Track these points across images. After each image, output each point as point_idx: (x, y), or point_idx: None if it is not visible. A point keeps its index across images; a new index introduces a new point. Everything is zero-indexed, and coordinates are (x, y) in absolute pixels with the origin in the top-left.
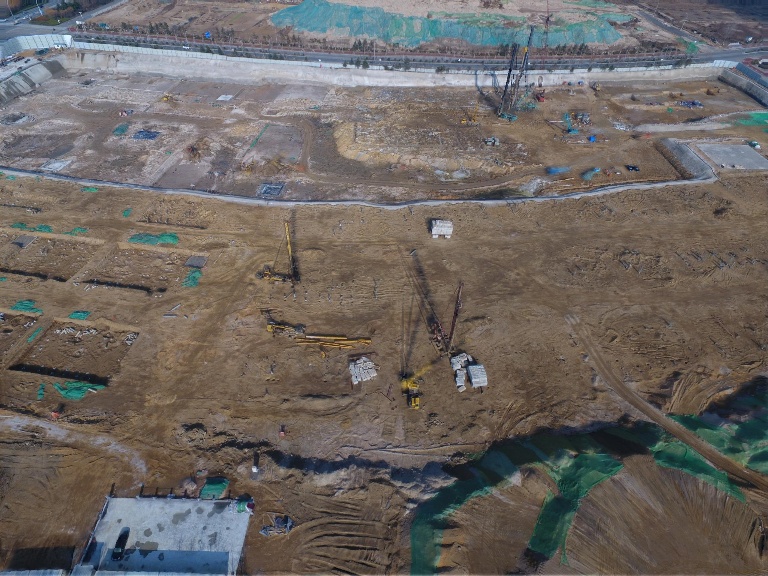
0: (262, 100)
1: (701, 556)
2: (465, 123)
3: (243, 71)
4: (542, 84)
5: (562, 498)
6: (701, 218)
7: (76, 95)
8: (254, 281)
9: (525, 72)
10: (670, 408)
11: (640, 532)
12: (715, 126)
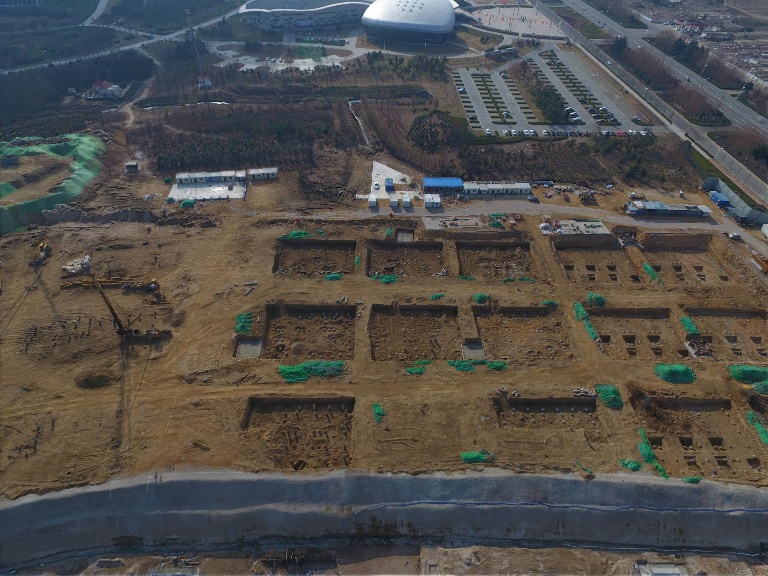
0: None
1: None
2: None
3: None
4: None
5: None
6: None
7: None
8: (174, 329)
9: None
10: None
11: None
12: None
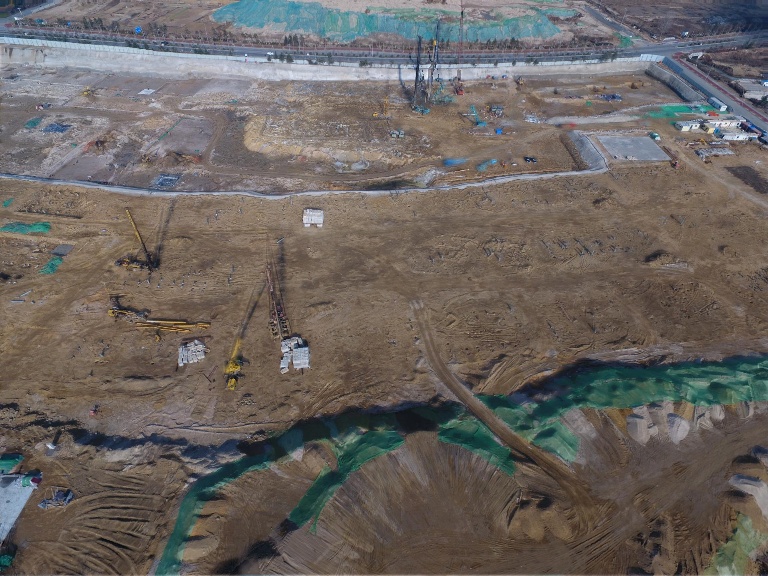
0: (183, 94)
1: (450, 526)
2: (377, 116)
3: (169, 66)
4: (466, 78)
5: (336, 472)
6: (579, 207)
7: None
8: (113, 268)
9: (449, 66)
10: (482, 388)
11: (398, 503)
12: (624, 118)
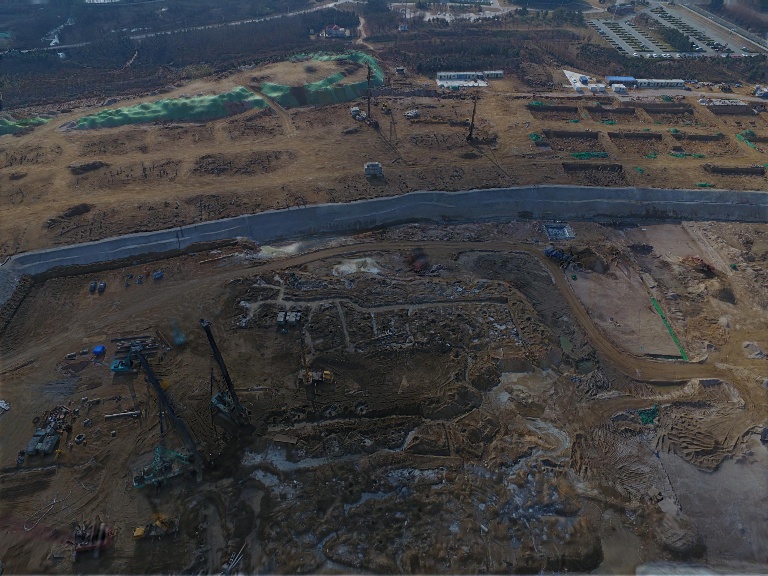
0: None
1: None
2: None
3: None
4: None
5: (330, 83)
6: (111, 205)
7: None
8: None
9: None
10: None
11: None
12: None
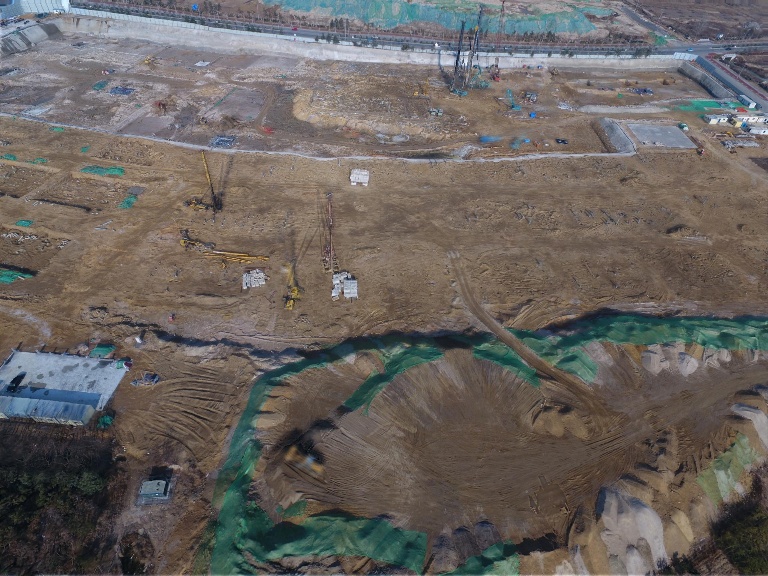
0: (236, 67)
1: (482, 419)
2: (417, 96)
3: (223, 41)
4: (502, 66)
5: (384, 374)
6: (606, 184)
7: (66, 54)
8: (181, 208)
9: (487, 54)
10: (511, 324)
11: (438, 400)
12: (654, 110)
